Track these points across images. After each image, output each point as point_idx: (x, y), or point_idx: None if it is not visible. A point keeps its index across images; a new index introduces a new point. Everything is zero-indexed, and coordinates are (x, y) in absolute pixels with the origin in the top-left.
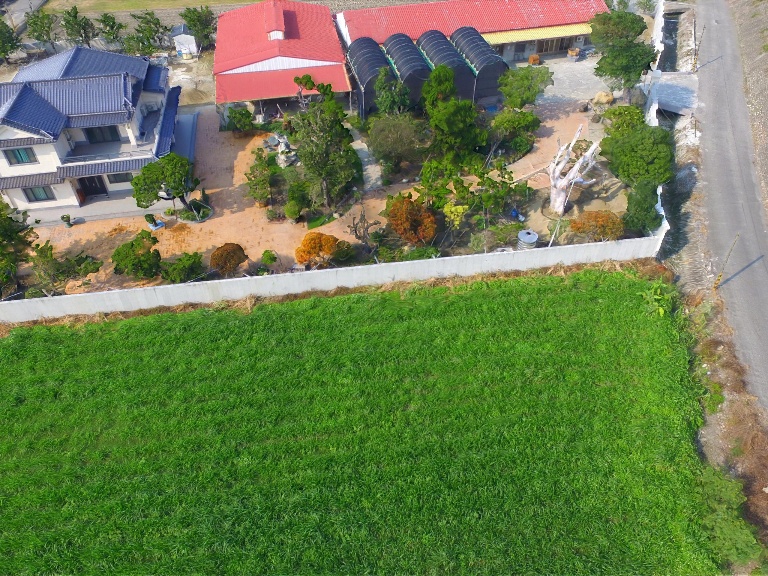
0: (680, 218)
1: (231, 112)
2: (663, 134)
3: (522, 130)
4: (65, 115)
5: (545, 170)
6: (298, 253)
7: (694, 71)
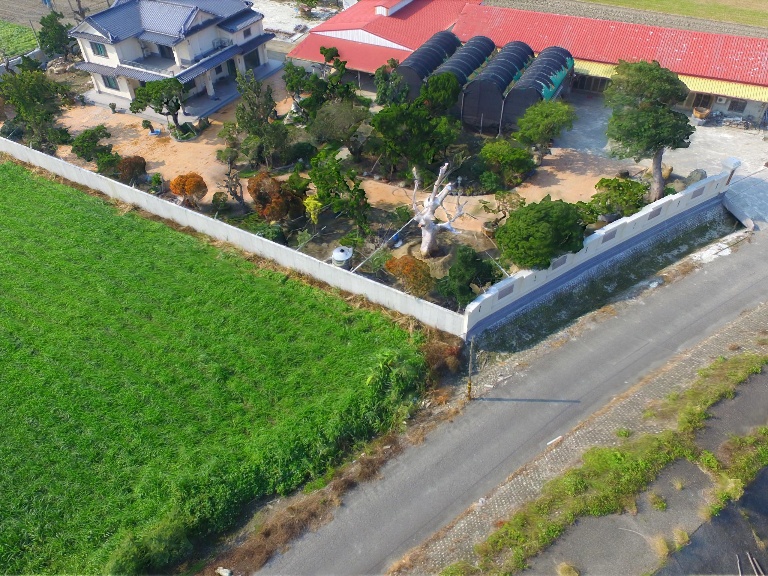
0: (566, 323)
1: (288, 66)
2: (561, 213)
3: (508, 167)
4: (143, 28)
5: (423, 202)
6: None
7: None
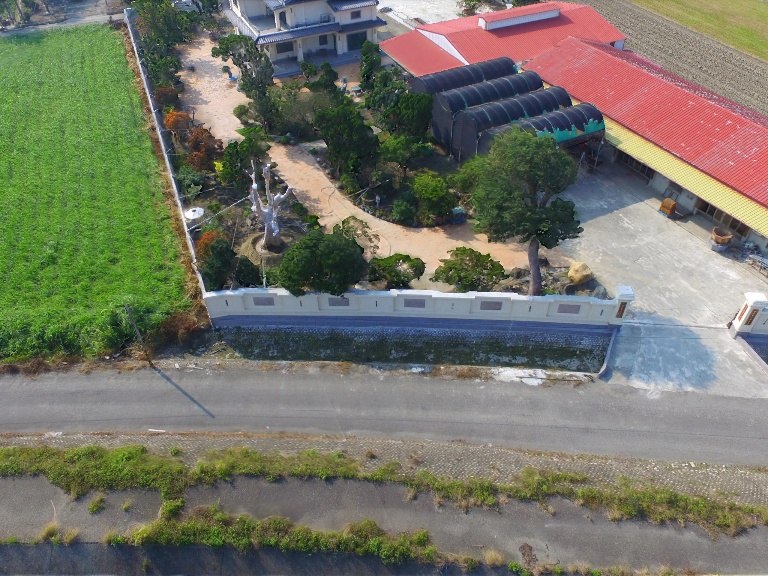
0: None
1: None
2: (324, 249)
3: None
4: None
5: None
6: None
7: None
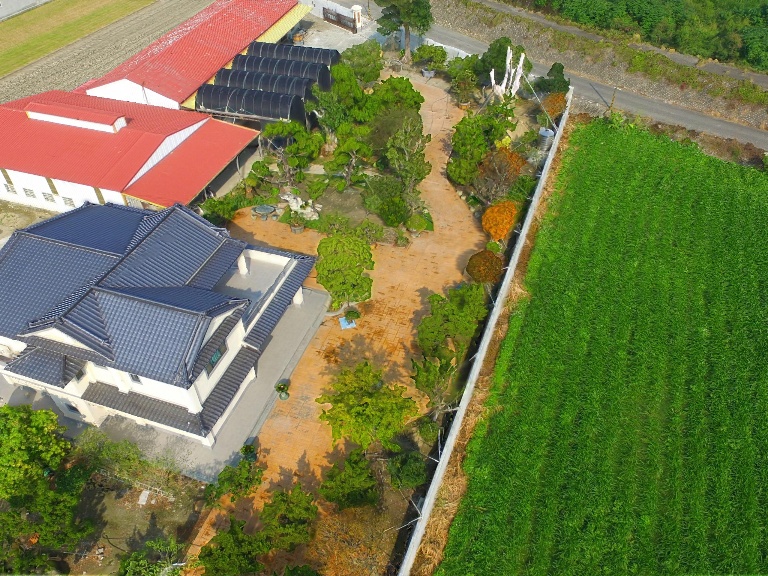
0: None
1: (208, 208)
2: None
3: None
4: (183, 286)
5: (495, 94)
6: (505, 228)
7: (373, 19)
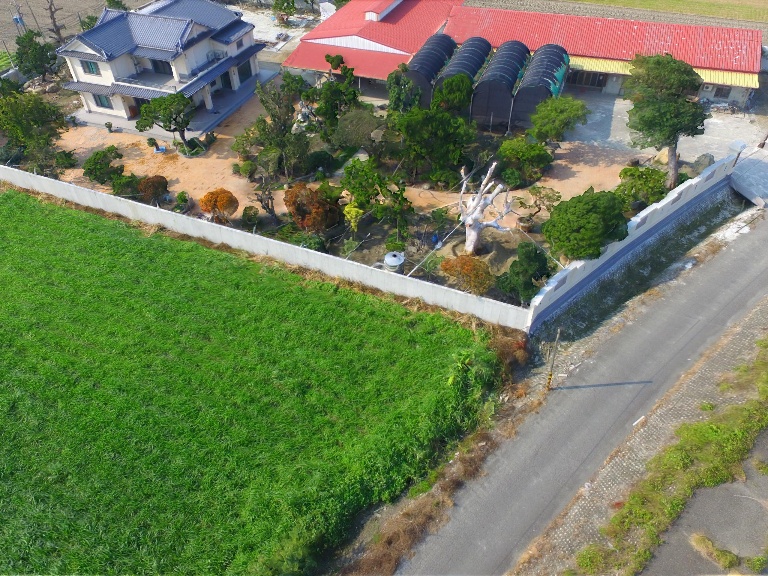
0: (616, 309)
1: (286, 75)
2: (608, 204)
3: (527, 163)
4: (136, 44)
5: (465, 202)
6: (200, 201)
7: None
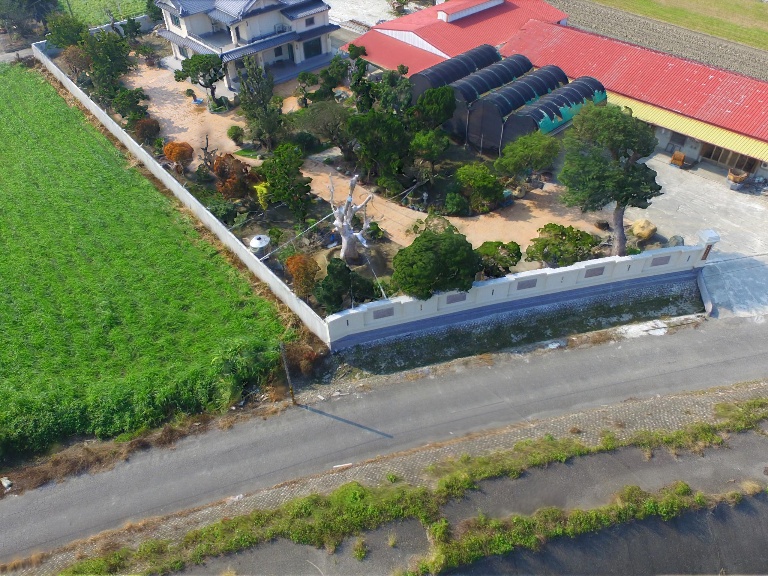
0: None
1: None
2: (449, 247)
3: (478, 193)
4: (215, 6)
5: None
6: None
7: None
